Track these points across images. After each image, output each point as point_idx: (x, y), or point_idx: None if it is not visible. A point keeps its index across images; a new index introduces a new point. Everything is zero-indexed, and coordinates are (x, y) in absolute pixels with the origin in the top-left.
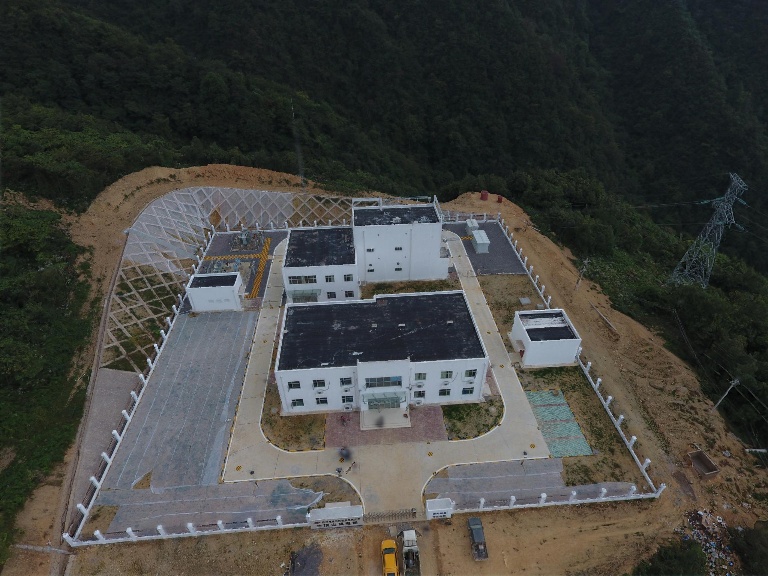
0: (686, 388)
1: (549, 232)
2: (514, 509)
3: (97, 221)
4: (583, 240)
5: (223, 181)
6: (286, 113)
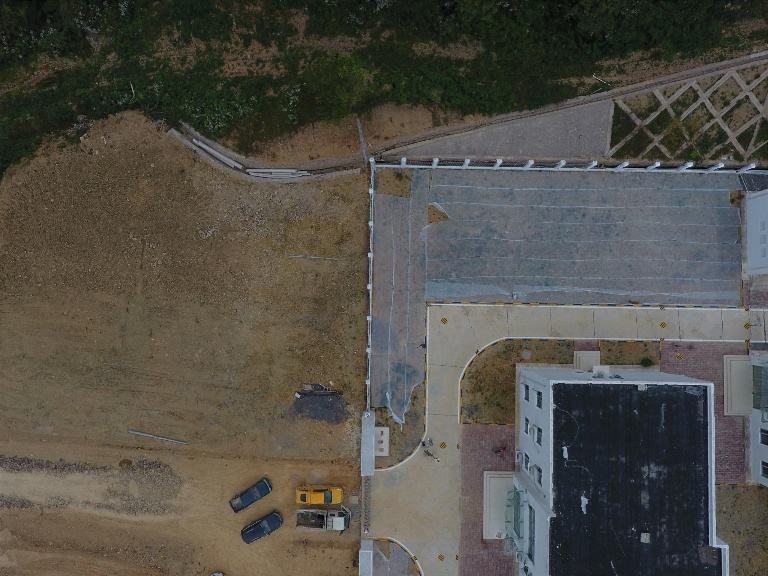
0: None
1: None
2: None
3: None
4: None
5: None
6: None
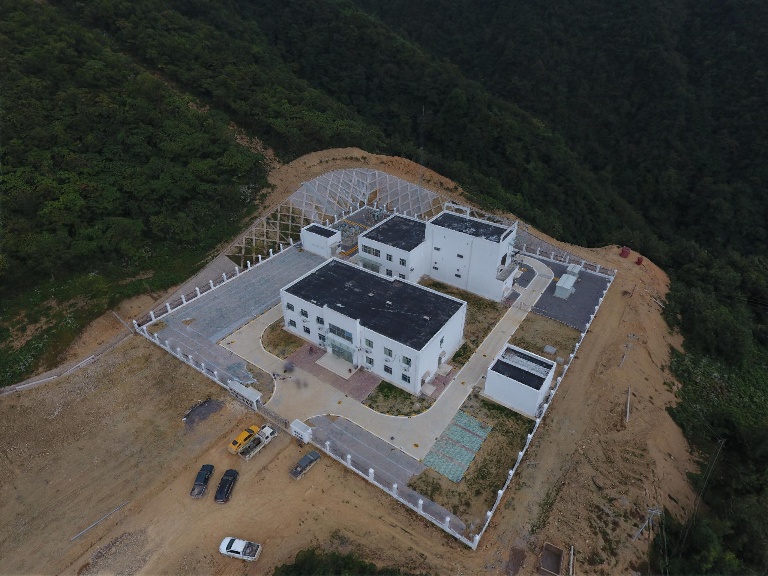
0: (634, 506)
1: (674, 313)
2: (351, 470)
3: (291, 171)
4: (699, 332)
5: (397, 171)
6: (508, 135)
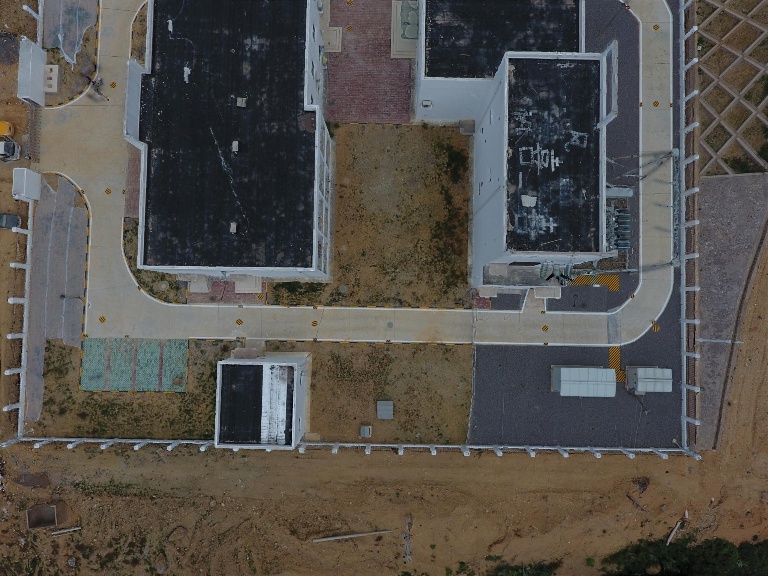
0: (170, 575)
1: (658, 561)
2: None
3: None
4: None
5: None
6: None
